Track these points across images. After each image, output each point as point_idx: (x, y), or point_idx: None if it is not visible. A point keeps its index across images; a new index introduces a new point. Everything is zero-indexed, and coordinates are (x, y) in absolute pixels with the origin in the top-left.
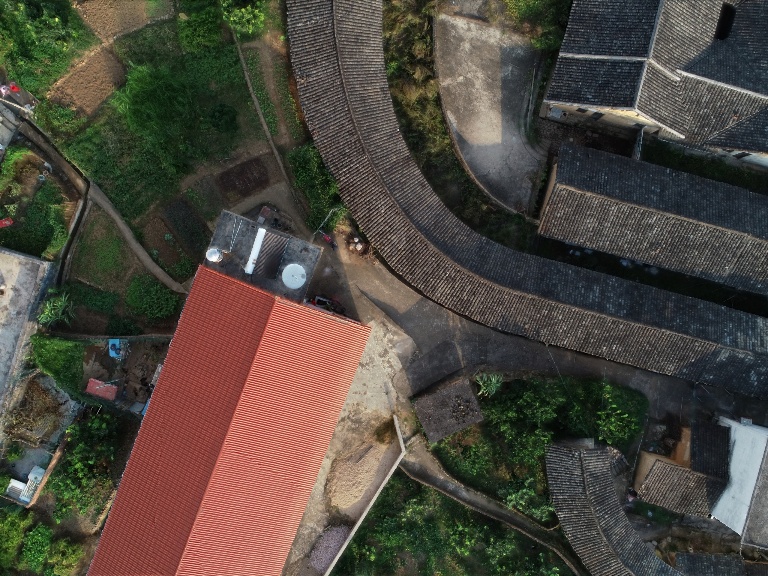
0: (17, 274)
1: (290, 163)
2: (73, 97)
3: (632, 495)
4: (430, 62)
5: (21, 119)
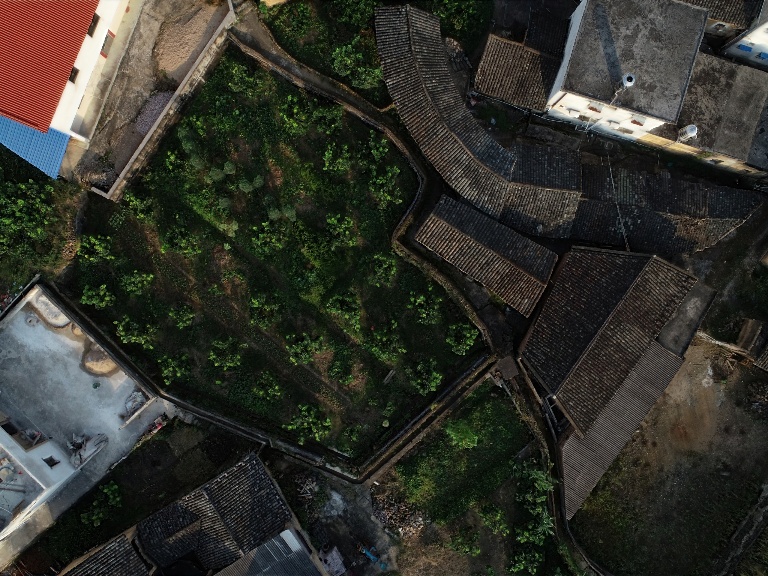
0: None
1: None
2: None
3: (475, 99)
4: None
5: None
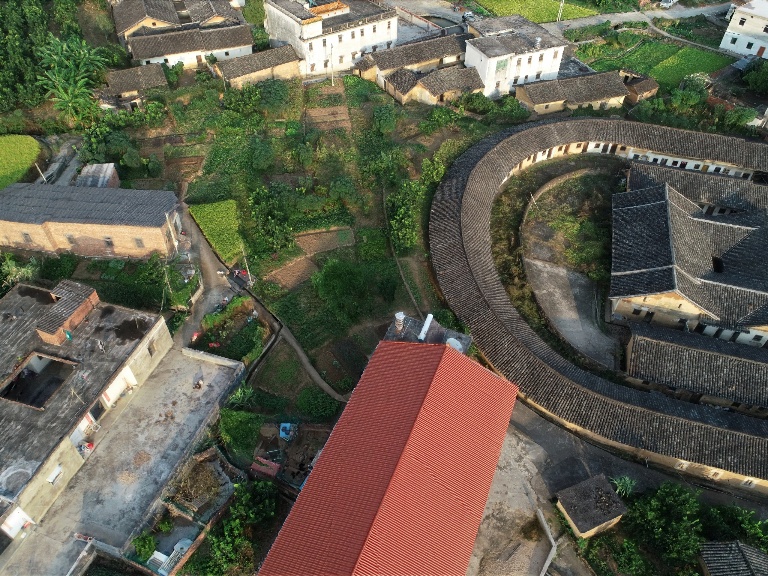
0: (215, 376)
1: (433, 317)
2: (281, 280)
3: None
4: (523, 277)
5: (243, 289)
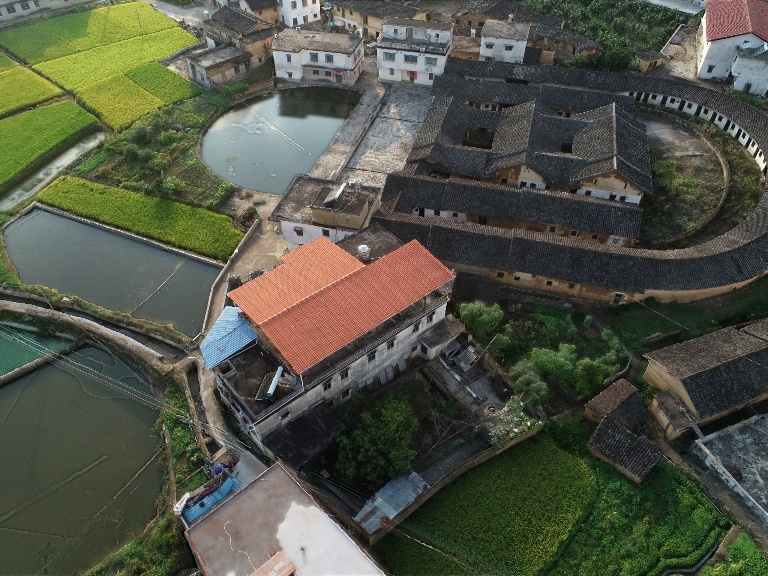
0: None
1: None
2: None
3: None
4: None
5: None
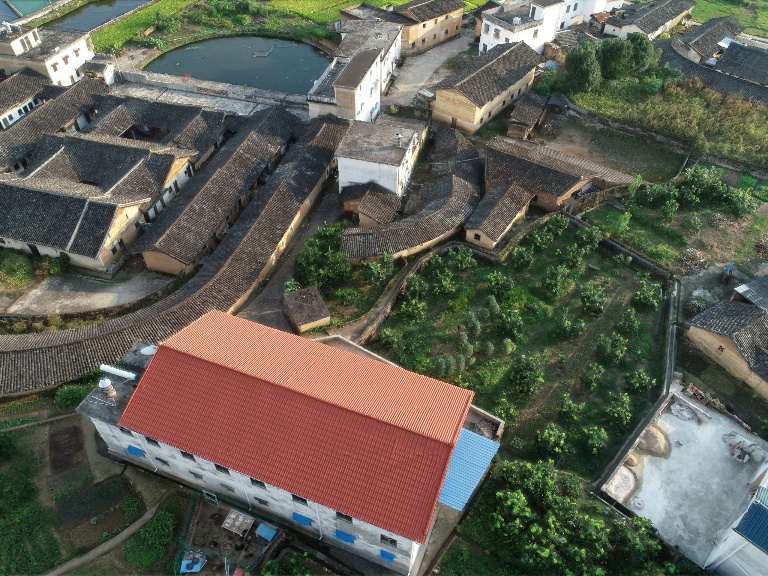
0: None
1: (66, 403)
2: None
3: None
4: (33, 321)
5: None
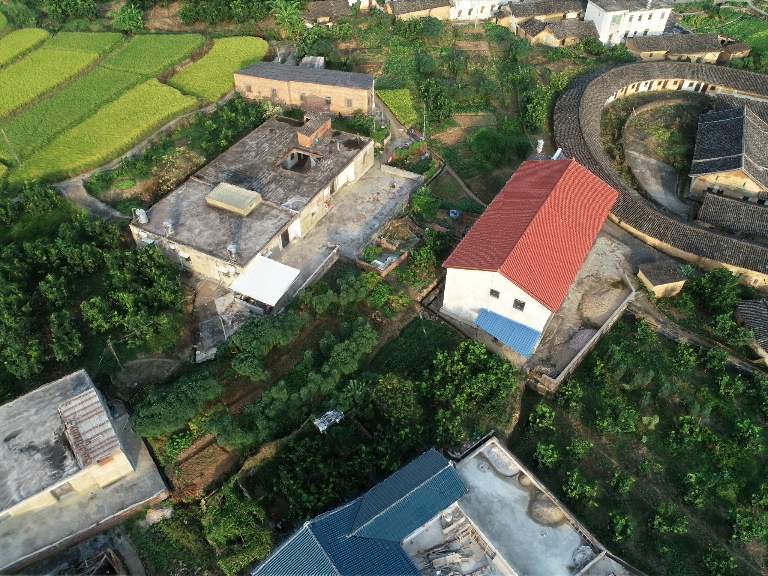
0: (403, 183)
1: None
2: (443, 140)
3: None
4: (623, 158)
5: None
